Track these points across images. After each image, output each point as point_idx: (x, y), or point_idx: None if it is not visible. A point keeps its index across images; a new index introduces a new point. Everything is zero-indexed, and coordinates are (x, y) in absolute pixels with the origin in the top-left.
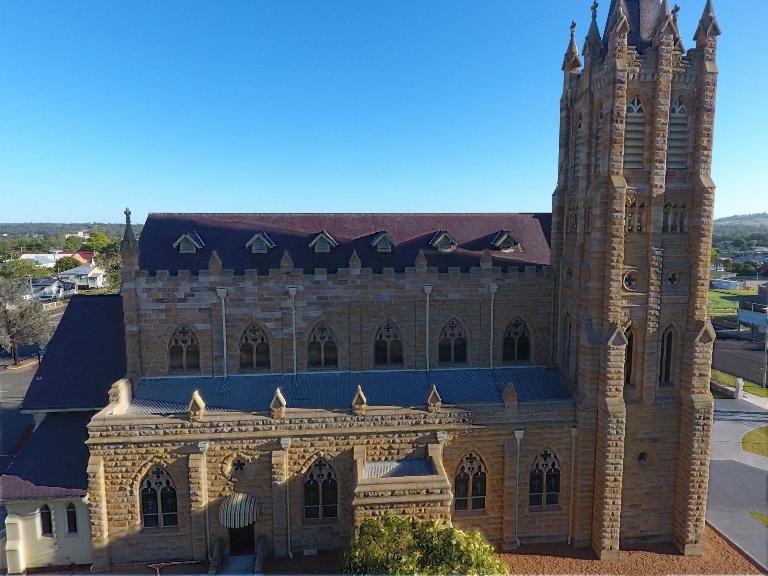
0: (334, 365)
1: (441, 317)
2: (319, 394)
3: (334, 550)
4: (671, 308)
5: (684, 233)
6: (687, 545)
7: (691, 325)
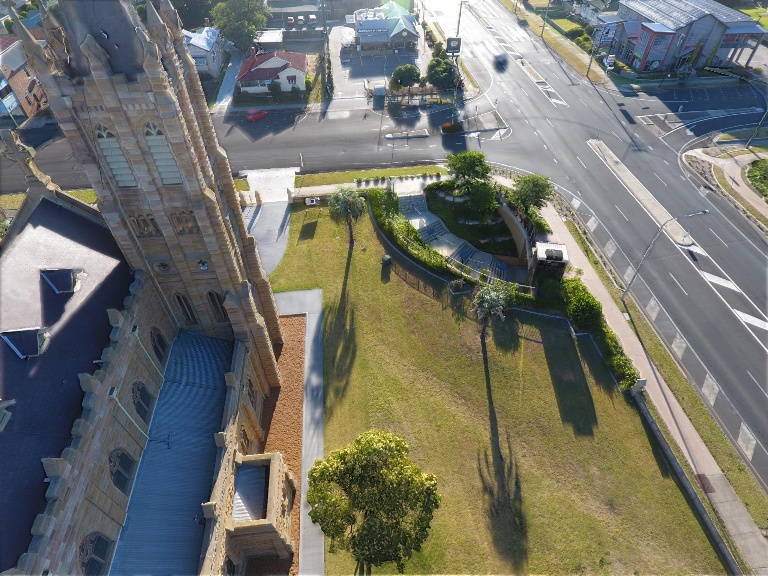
0: (108, 546)
1: (128, 397)
2: (146, 568)
3: (246, 575)
4: (238, 243)
5: (221, 191)
6: (282, 339)
7: (246, 243)
